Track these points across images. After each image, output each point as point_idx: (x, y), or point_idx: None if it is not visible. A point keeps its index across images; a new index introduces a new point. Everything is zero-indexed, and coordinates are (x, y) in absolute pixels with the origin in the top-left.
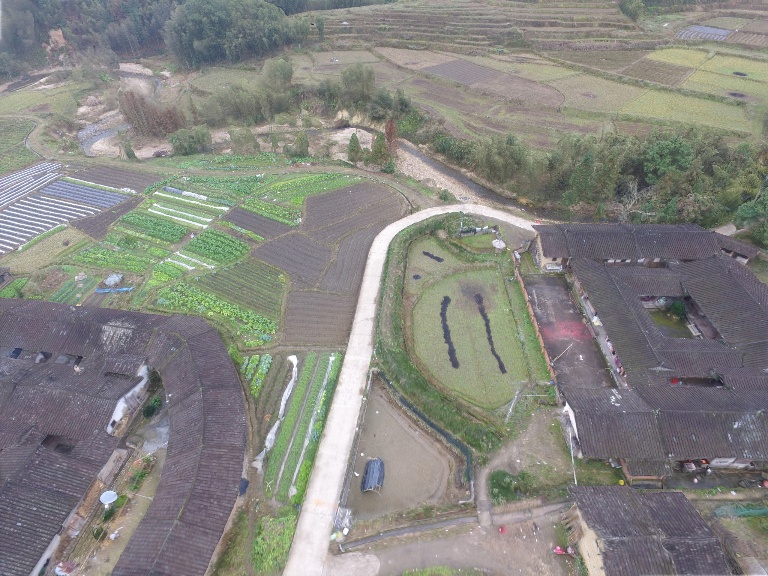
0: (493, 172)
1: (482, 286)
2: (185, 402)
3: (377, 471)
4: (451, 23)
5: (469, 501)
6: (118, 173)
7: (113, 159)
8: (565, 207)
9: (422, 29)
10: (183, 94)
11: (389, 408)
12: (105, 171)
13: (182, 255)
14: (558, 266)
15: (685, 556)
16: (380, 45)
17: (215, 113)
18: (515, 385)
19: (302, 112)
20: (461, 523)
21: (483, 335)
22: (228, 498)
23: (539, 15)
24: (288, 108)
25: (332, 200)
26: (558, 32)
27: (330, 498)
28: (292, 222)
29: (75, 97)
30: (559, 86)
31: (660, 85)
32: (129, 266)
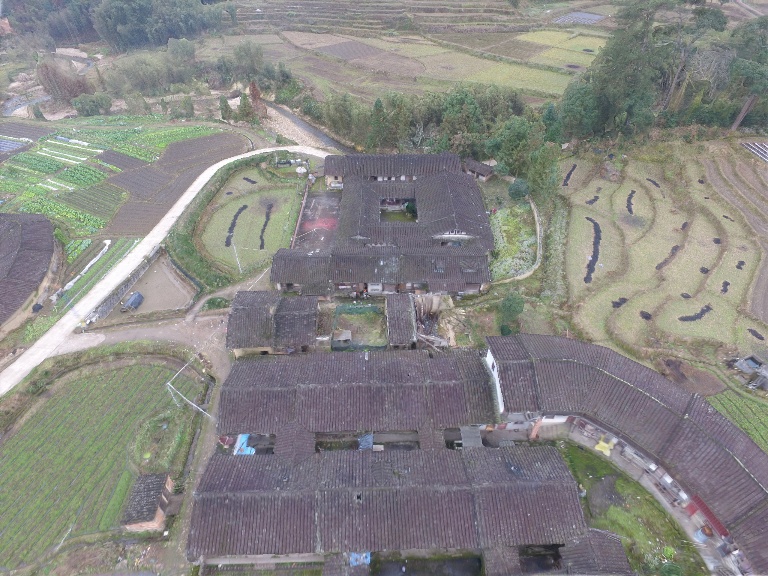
0: (336, 125)
1: (277, 199)
2: (6, 257)
3: (133, 298)
4: (352, 10)
5: (182, 308)
6: (22, 128)
7: (23, 118)
8: (391, 152)
9: (325, 15)
10: (105, 71)
11: (165, 269)
12: (12, 126)
13: (51, 181)
14: (339, 184)
15: (290, 321)
16: (288, 29)
17: (123, 84)
18: (265, 256)
19: (203, 85)
20: (172, 320)
21: (259, 228)
22: (14, 305)
23: (431, 2)
24: (191, 81)
25: (190, 145)
26: (444, 17)
27: (88, 308)
28: (150, 159)
29: (10, 74)
30: (426, 61)
31: (512, 59)
32: (7, 188)
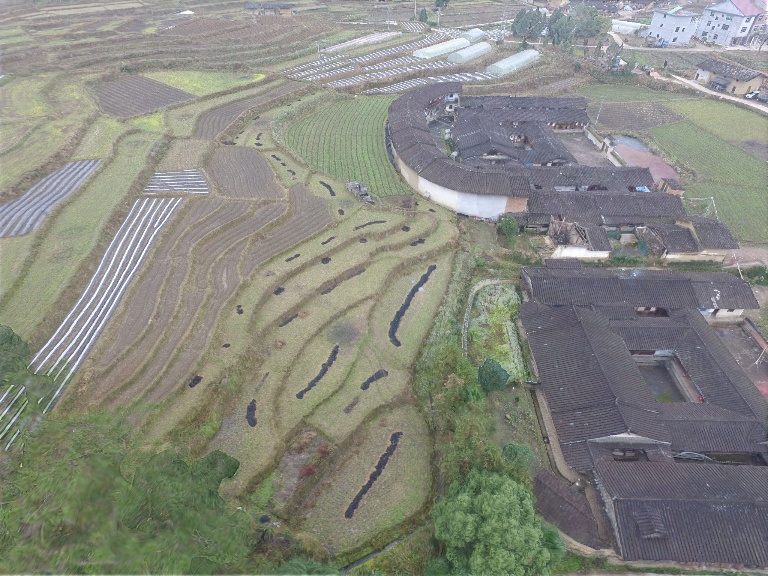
0: None
1: None
2: None
3: None
4: None
5: None
6: None
7: None
8: None
9: None
10: None
11: None
12: None
13: None
14: None
15: None
16: None
17: None
18: None
19: None
20: None
21: None
22: None
23: None
24: None
25: None
26: None
27: None
28: None
29: None
30: None
31: None
32: None
